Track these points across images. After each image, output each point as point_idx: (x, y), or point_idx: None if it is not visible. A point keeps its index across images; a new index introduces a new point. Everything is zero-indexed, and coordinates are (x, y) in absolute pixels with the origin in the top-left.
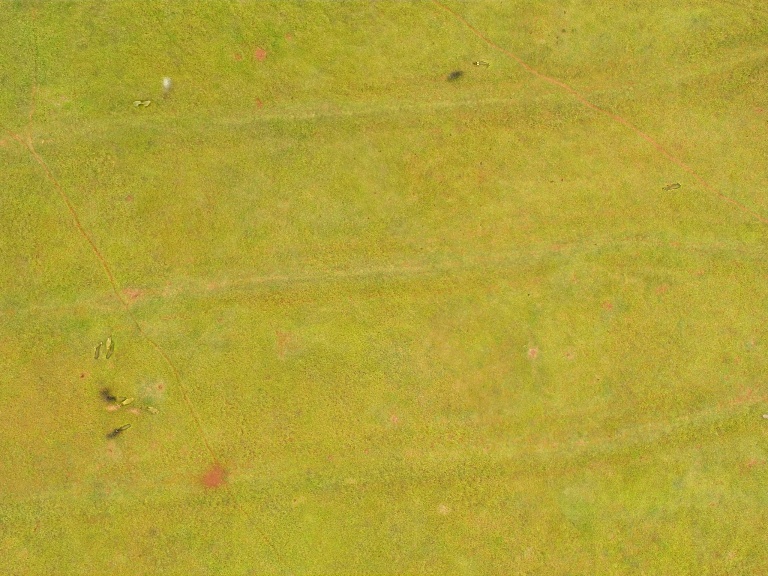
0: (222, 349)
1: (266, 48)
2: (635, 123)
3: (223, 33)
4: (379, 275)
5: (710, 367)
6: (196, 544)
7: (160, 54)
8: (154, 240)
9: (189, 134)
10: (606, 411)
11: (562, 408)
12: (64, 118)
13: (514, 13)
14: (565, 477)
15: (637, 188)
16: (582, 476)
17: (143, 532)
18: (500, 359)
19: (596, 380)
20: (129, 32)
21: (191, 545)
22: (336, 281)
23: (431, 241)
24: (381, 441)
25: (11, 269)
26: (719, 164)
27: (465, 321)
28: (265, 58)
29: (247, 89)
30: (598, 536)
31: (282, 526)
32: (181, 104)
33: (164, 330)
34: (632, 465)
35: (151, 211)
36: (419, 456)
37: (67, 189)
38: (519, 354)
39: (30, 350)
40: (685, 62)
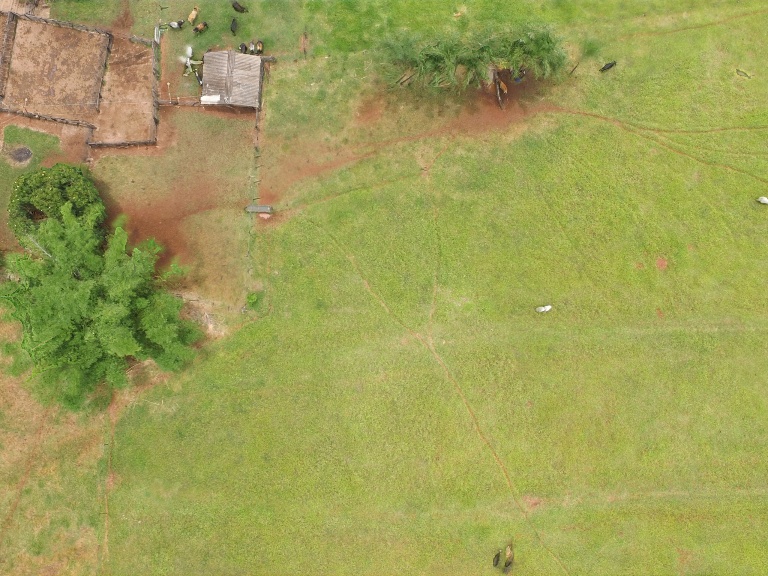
0: (622, 563)
1: (668, 258)
2: None
3: (625, 240)
4: None
5: None
6: None
7: (561, 259)
8: (554, 448)
9: (590, 342)
10: None
11: None
12: (464, 319)
13: None
14: None
15: None
16: None
17: None
18: None
19: None
20: (532, 236)
21: None
22: (737, 500)
23: None
24: None
25: (411, 470)
26: None
27: None
28: (666, 268)
29: (648, 298)
30: None
31: None
32: (582, 310)
33: (564, 541)
34: None
35: (551, 418)
36: None
37: (467, 391)
38: None
39: (429, 554)
40: None
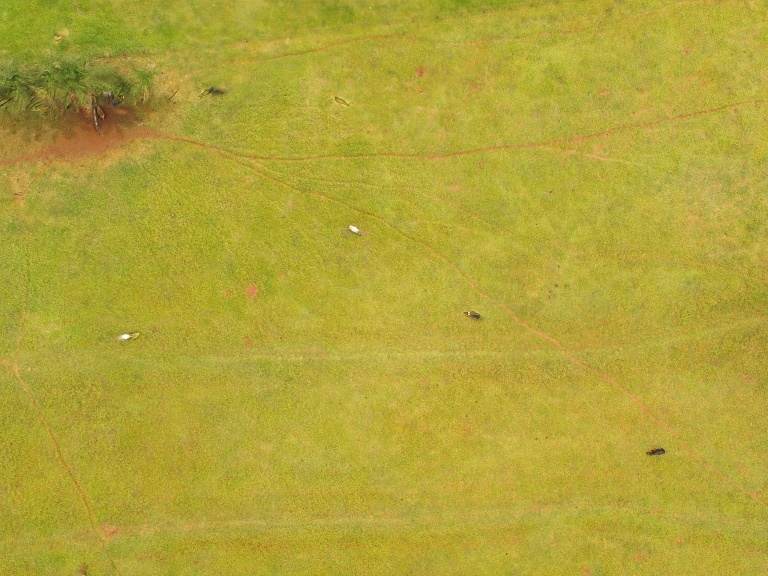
0: None
1: (258, 286)
2: (623, 384)
3: (216, 268)
4: (358, 526)
5: None
6: None
7: (152, 286)
8: (134, 476)
9: (176, 370)
10: None
11: None
12: (52, 346)
13: (508, 264)
14: None
15: (621, 450)
16: None
17: None
18: None
19: None
20: (122, 262)
21: None
22: (314, 529)
23: (412, 493)
24: None
25: None
26: (705, 431)
27: None
28: (256, 296)
29: (236, 326)
30: None
31: None
32: (170, 338)
33: (139, 570)
34: None
35: (133, 446)
36: None
37: (51, 419)
38: None
39: None
40: (676, 325)
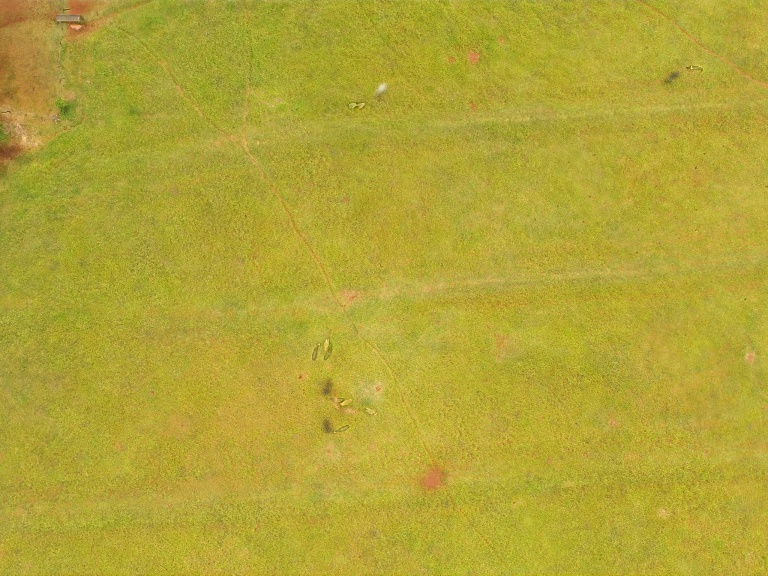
0: (440, 351)
1: (480, 51)
2: None
3: (436, 36)
4: (596, 279)
5: None
6: (417, 545)
7: (374, 56)
8: (370, 242)
9: (404, 136)
10: None
11: None
12: (278, 120)
13: (728, 18)
14: None
15: None
16: None
17: (363, 533)
18: (718, 363)
19: None
20: (343, 34)
21: (412, 546)
22: (552, 284)
23: (646, 245)
24: (599, 444)
25: (228, 270)
26: None
27: (682, 325)
28: (478, 61)
29: (461, 92)
30: None
31: (502, 528)
32: (395, 106)
33: (382, 332)
34: None
35: (367, 213)
36: (638, 460)
37: (282, 190)
38: (737, 358)
39: (248, 351)
40: None
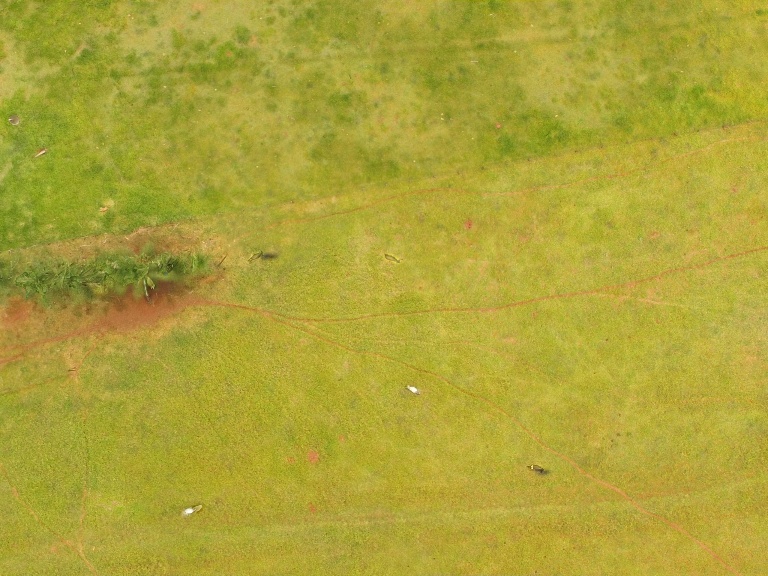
0: None
1: (319, 451)
2: (691, 531)
3: (275, 435)
4: None
5: None
6: None
7: (212, 457)
8: None
9: (241, 541)
10: None
11: None
12: (115, 523)
13: (568, 416)
14: None
15: None
16: None
17: None
18: None
19: None
20: (181, 435)
21: None
22: None
23: None
24: None
25: None
26: None
27: None
28: (318, 461)
29: (299, 493)
30: None
31: None
32: (233, 509)
33: None
34: None
35: None
36: None
37: None
38: None
39: None
40: (741, 468)
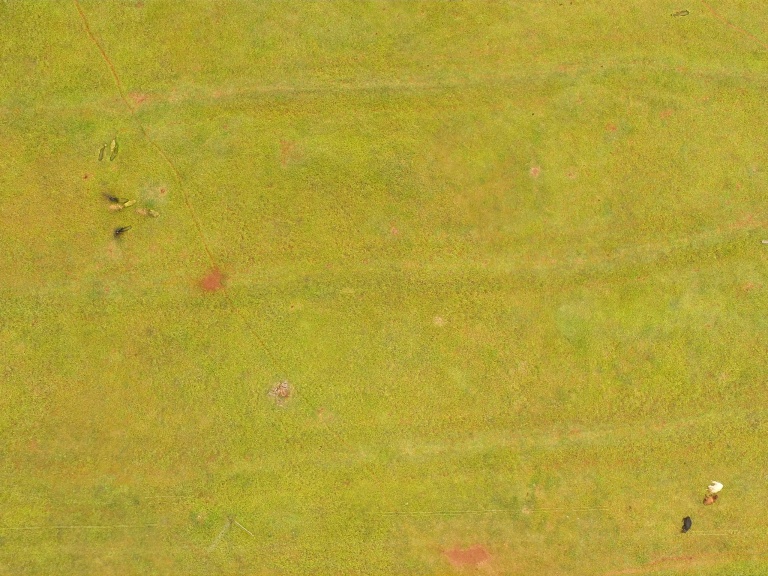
0: (225, 155)
1: None
2: None
3: None
4: (385, 89)
5: (711, 192)
6: (192, 345)
7: None
8: (162, 46)
9: None
10: (605, 231)
11: (562, 227)
12: None
13: None
14: (562, 294)
15: (646, 14)
16: (579, 293)
17: (140, 331)
18: (502, 176)
19: (597, 200)
20: None
21: (187, 345)
22: (342, 94)
23: (438, 58)
24: (380, 252)
25: (19, 69)
26: None
27: (469, 137)
28: None
29: None
30: (592, 352)
31: (278, 331)
32: None
33: (169, 134)
34: (629, 284)
35: (160, 18)
36: (417, 268)
37: None
38: (521, 172)
39: (35, 149)
40: None
